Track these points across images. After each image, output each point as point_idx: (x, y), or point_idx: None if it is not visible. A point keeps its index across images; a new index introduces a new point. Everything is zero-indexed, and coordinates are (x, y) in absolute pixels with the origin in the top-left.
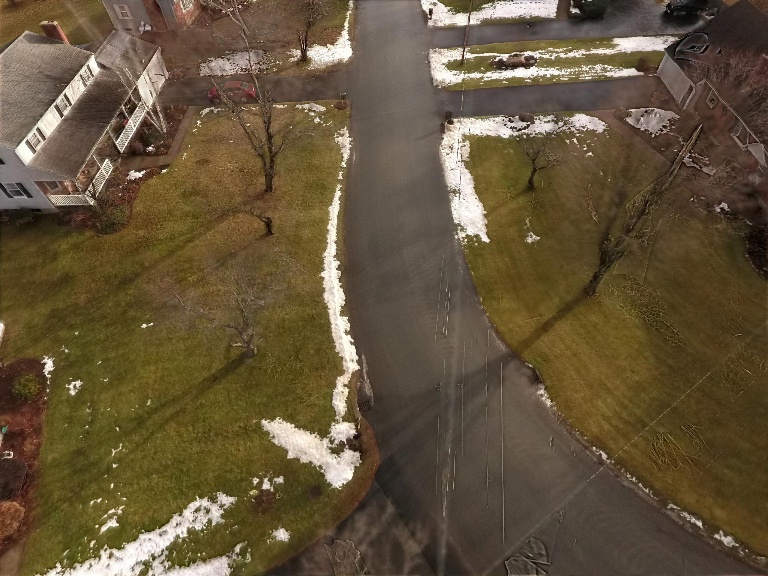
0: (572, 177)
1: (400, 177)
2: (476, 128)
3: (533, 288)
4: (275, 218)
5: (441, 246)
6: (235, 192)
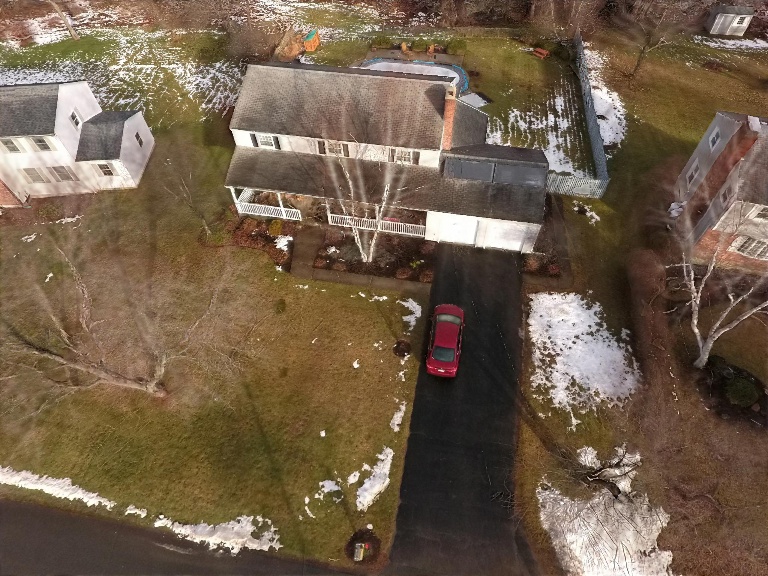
0: None
1: None
2: None
3: None
4: (99, 396)
5: None
6: None
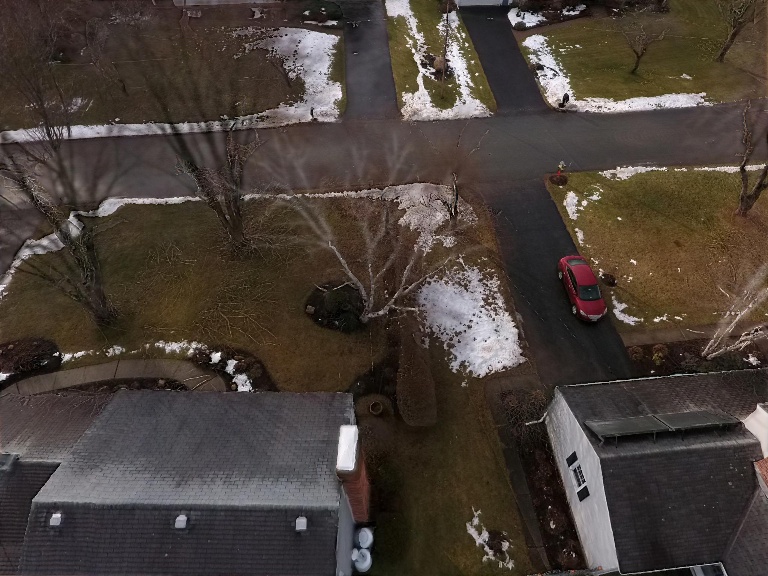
0: (611, 55)
1: (661, 133)
2: (564, 92)
3: (734, 79)
4: None
5: (727, 112)
6: (761, 244)
